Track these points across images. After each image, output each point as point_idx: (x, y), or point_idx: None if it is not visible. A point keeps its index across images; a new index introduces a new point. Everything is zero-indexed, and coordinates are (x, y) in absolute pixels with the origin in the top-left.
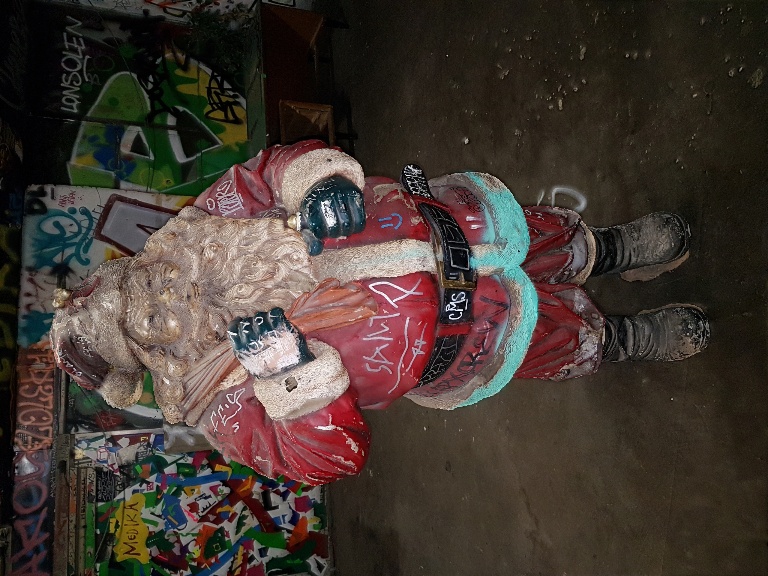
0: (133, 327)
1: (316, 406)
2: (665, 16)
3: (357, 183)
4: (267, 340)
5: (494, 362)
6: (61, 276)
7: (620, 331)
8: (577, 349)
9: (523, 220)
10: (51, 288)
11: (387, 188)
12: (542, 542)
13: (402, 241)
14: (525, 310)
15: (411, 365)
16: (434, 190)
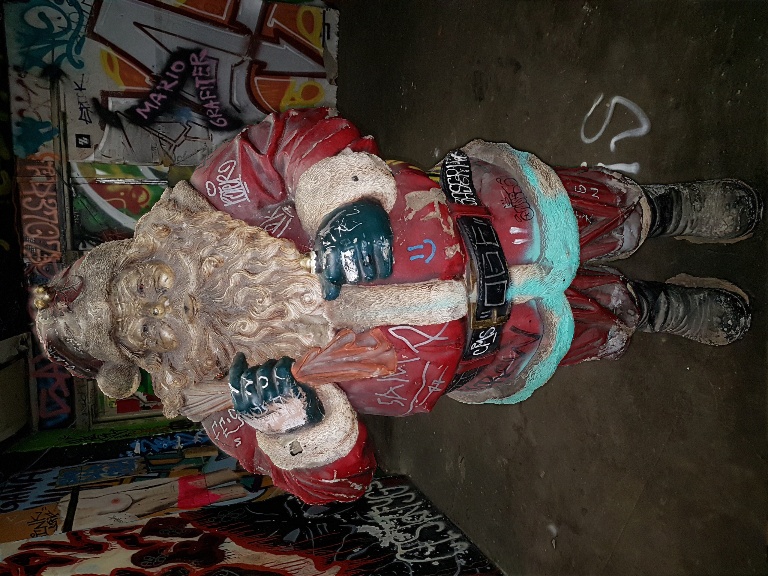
0: (126, 337)
1: (321, 462)
2: None
3: (386, 202)
4: (271, 406)
5: (514, 383)
6: (53, 80)
7: (653, 308)
8: None
9: (576, 238)
10: (44, 93)
11: (422, 198)
12: (528, 440)
13: (432, 286)
14: (558, 343)
15: (425, 400)
16: (477, 174)
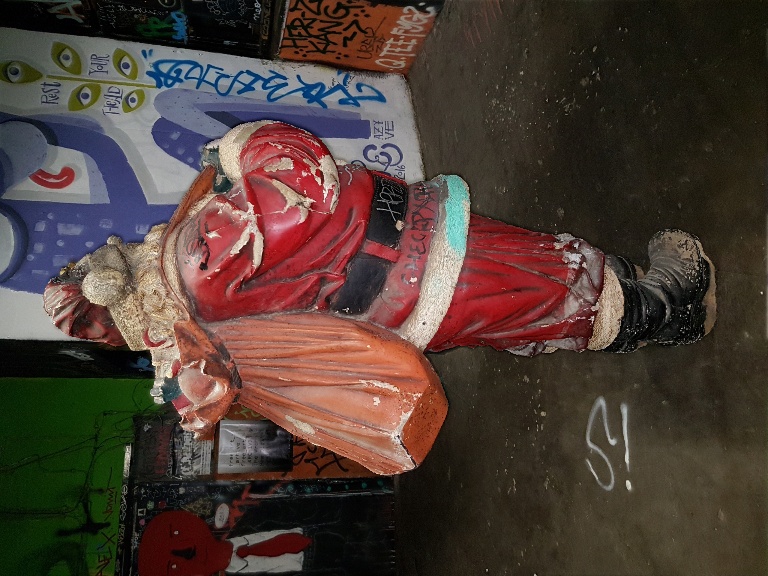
0: None
1: None
2: None
3: None
4: None
5: (442, 188)
6: None
7: None
8: None
9: None
10: None
11: None
12: None
13: None
14: None
15: None
16: None
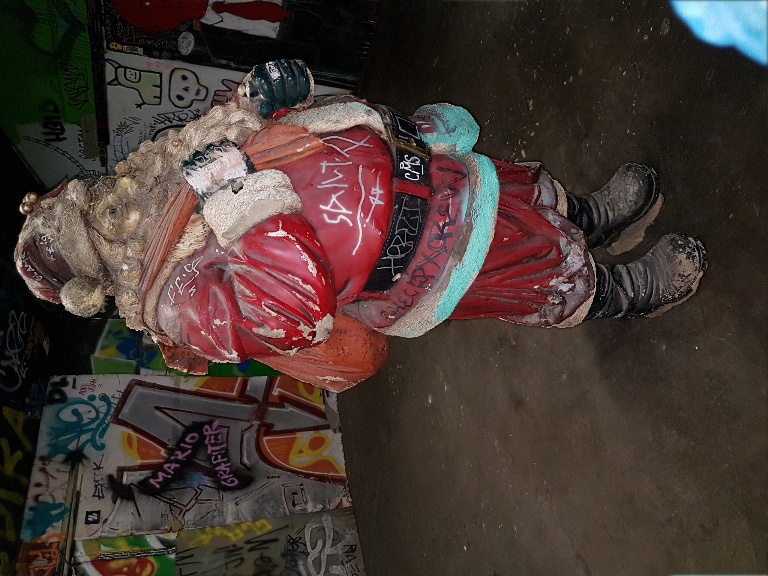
0: (95, 217)
1: (265, 214)
2: (584, 35)
3: None
4: (213, 154)
5: (464, 233)
6: (74, 463)
7: (614, 273)
8: (563, 263)
9: (470, 117)
10: (63, 476)
11: None
12: None
13: None
14: (483, 174)
15: (371, 215)
16: None
